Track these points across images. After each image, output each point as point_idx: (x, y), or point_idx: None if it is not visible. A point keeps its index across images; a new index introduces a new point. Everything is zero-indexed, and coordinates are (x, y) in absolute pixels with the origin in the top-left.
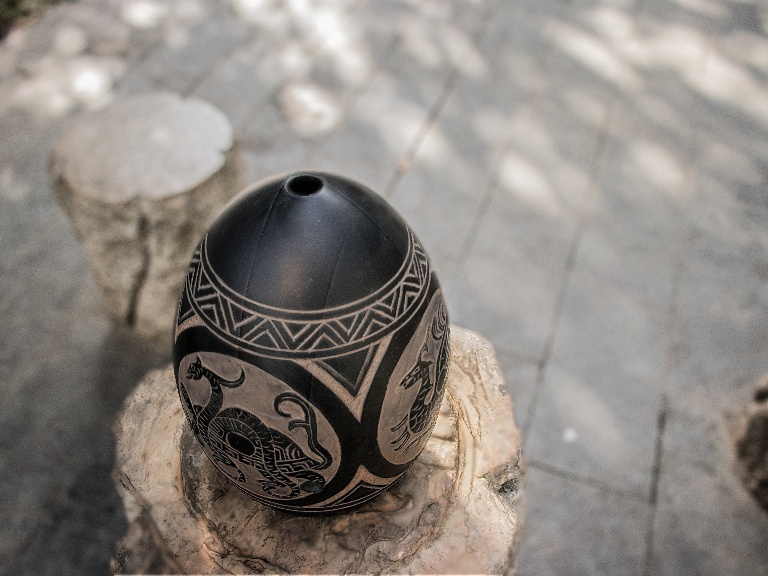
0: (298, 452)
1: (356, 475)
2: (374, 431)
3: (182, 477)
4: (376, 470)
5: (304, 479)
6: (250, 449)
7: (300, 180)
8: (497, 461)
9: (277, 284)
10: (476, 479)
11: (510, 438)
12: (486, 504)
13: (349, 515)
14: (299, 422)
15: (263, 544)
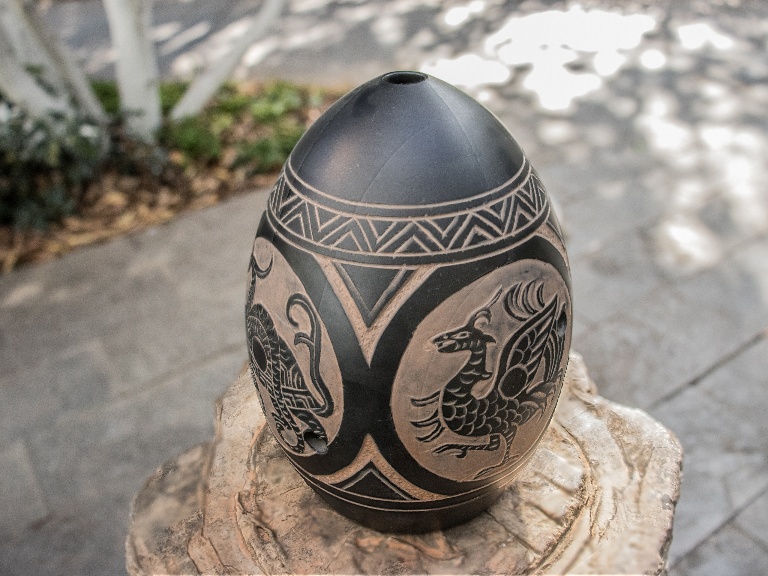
0: (300, 379)
1: (364, 449)
2: (387, 389)
3: None
4: (391, 456)
5: (306, 424)
6: (264, 362)
7: (406, 77)
8: (606, 575)
9: (325, 163)
10: None
11: (641, 558)
12: None
13: (384, 536)
14: (305, 337)
15: (284, 519)
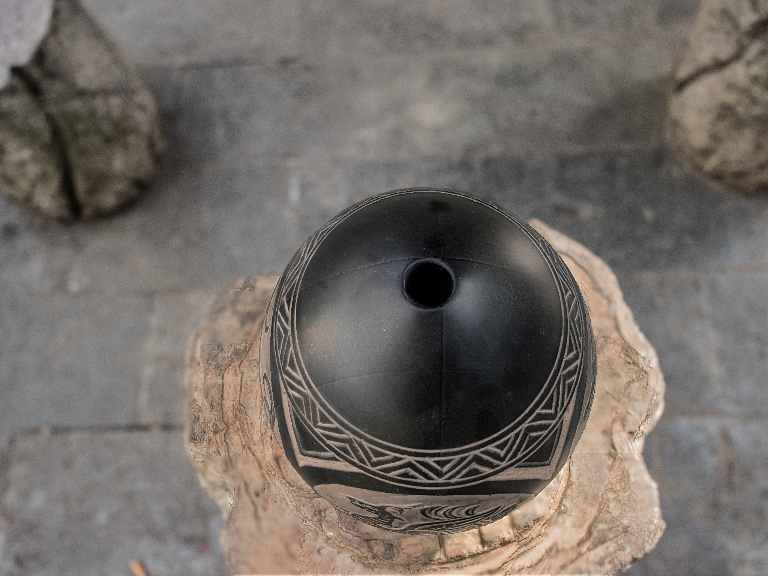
0: None
1: None
2: None
3: None
4: None
5: None
6: None
7: (441, 272)
8: None
9: (310, 321)
10: None
11: None
12: None
13: None
14: None
15: None
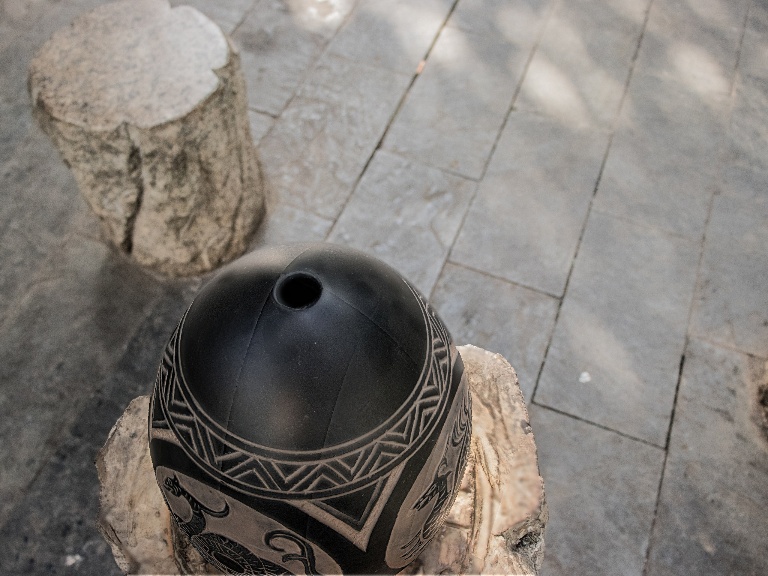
0: None
1: None
2: (382, 555)
3: (172, 530)
4: None
5: None
6: (239, 569)
7: (293, 280)
8: (517, 516)
9: (265, 420)
10: (493, 538)
11: (532, 488)
12: (503, 569)
13: None
14: (294, 556)
15: None
